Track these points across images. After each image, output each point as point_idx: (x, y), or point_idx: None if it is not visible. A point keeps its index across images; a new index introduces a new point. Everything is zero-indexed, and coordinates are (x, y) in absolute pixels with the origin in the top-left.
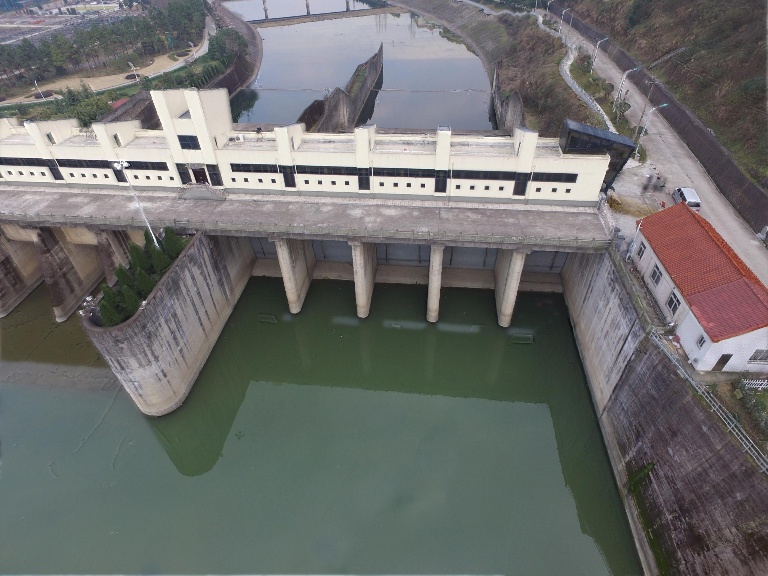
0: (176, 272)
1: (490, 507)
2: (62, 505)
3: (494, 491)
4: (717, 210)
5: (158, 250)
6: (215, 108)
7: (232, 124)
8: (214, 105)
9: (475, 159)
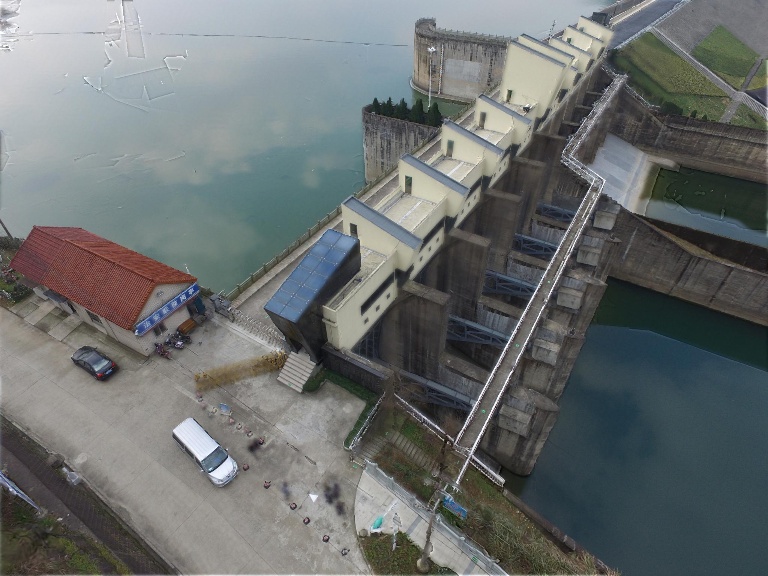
0: (404, 125)
1: (203, 271)
2: (340, 160)
3: (207, 276)
4: (157, 495)
5: (413, 109)
6: (528, 70)
7: (548, 100)
8: (528, 67)
9: (385, 203)
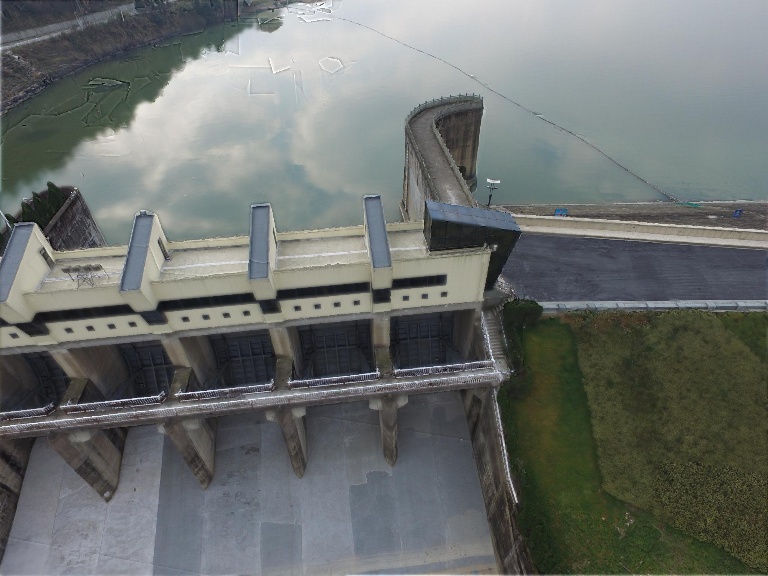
0: None
1: None
2: None
3: None
4: None
5: None
6: None
7: None
8: None
9: None
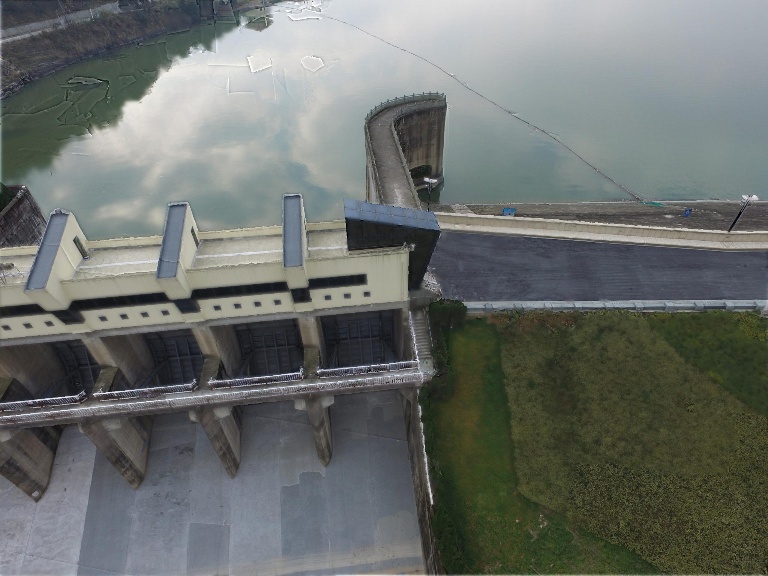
0: None
1: None
2: None
3: None
4: None
5: None
6: None
7: None
8: None
9: None
